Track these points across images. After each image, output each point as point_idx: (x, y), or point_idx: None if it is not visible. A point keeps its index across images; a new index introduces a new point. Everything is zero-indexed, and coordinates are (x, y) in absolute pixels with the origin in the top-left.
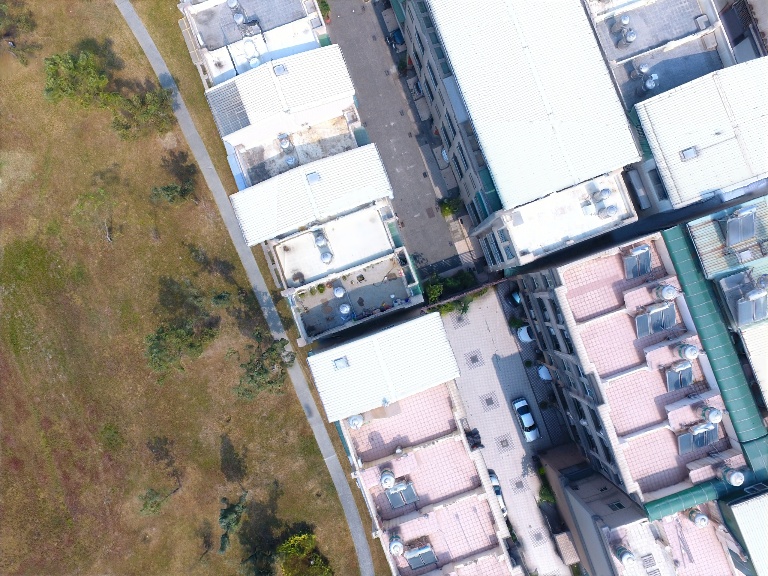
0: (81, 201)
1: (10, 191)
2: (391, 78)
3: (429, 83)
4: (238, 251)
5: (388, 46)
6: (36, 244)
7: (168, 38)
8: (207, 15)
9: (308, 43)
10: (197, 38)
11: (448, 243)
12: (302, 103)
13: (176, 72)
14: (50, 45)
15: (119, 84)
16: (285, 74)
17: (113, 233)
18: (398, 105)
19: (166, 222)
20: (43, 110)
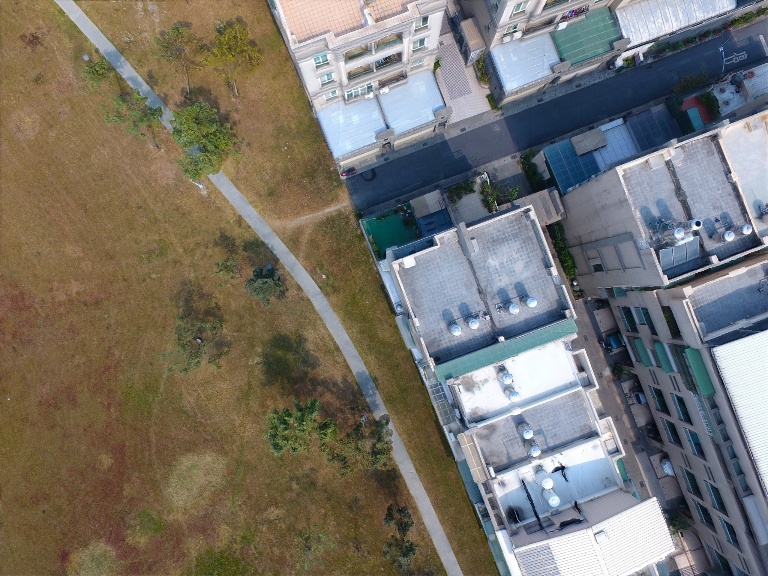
0: (276, 509)
1: (201, 498)
2: (604, 381)
3: (679, 434)
4: (443, 561)
5: (601, 348)
6: (229, 554)
7: (365, 334)
8: (488, 429)
9: (598, 460)
10: (487, 468)
11: (668, 557)
12: (624, 571)
13: (374, 370)
14: (240, 342)
15: (314, 383)
16: (606, 540)
17: (311, 542)
18: (612, 410)
19: (366, 530)
20: (234, 411)
